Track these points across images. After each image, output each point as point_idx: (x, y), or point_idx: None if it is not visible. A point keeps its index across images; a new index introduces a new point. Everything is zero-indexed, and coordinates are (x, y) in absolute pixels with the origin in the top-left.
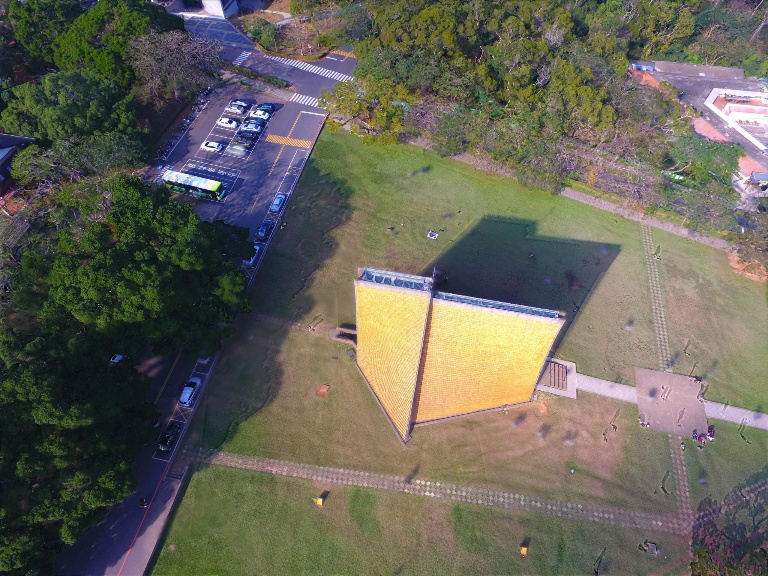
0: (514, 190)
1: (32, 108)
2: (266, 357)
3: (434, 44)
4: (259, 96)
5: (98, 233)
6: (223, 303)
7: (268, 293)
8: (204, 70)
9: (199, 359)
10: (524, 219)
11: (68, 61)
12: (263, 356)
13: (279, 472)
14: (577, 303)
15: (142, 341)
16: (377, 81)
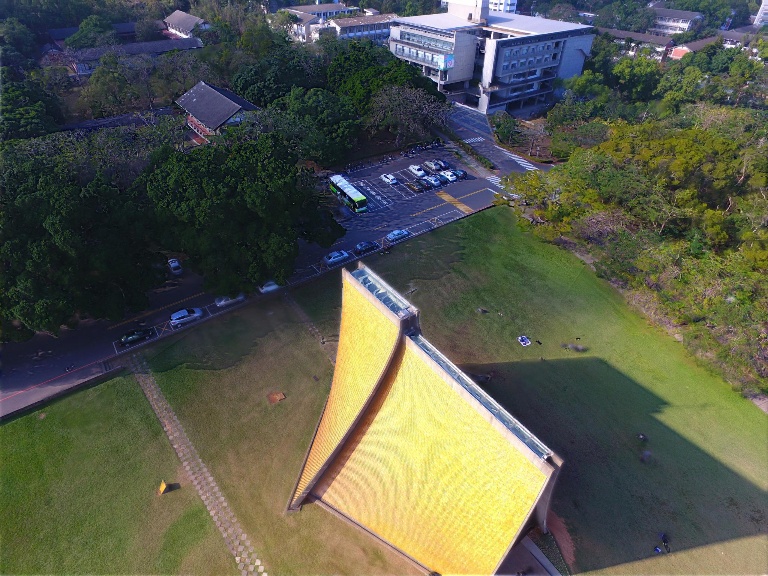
0: (676, 358)
1: (291, 102)
2: (264, 335)
3: (657, 164)
4: (462, 166)
5: (219, 152)
6: (263, 260)
7: (319, 291)
8: (421, 120)
9: (217, 299)
10: (665, 394)
11: (341, 89)
12: (263, 333)
13: (169, 432)
14: (671, 542)
15: (177, 241)
16: (570, 178)
